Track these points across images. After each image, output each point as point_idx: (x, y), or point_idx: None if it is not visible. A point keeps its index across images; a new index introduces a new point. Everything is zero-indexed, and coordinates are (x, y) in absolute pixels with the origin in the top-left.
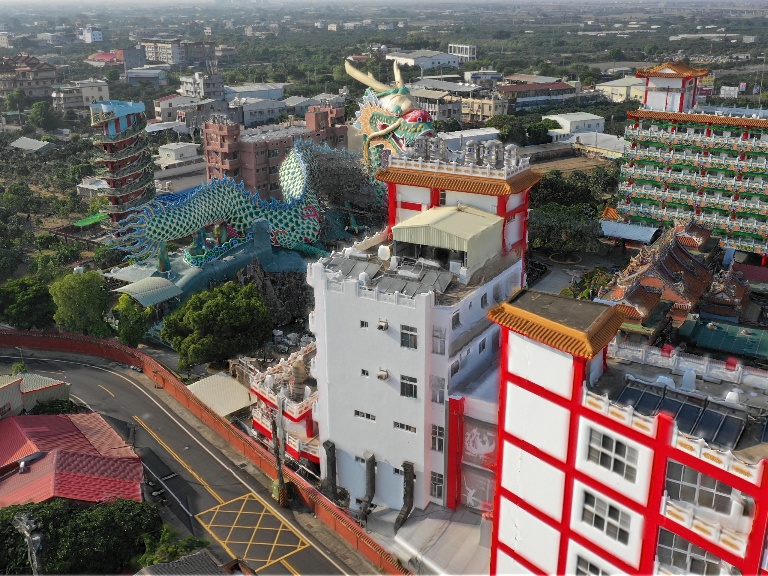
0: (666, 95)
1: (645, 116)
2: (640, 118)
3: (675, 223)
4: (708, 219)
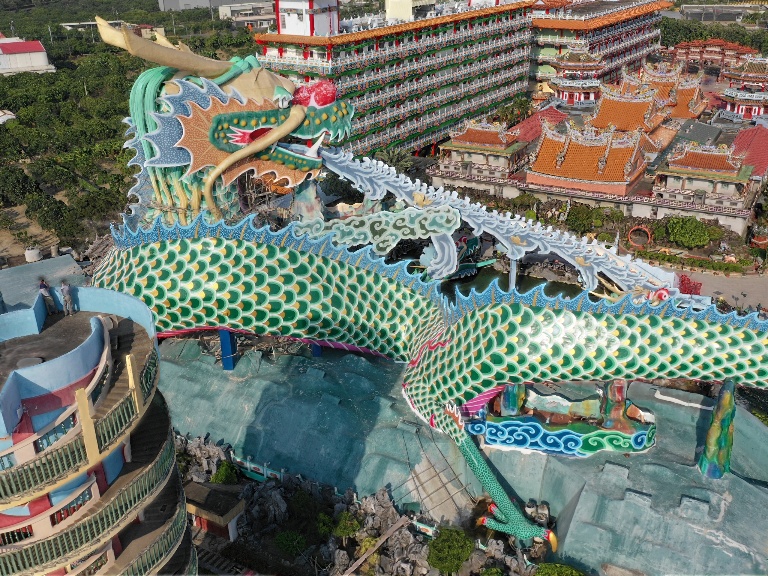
0: (329, 16)
1: (344, 42)
2: (333, 46)
3: (451, 135)
4: (392, 134)
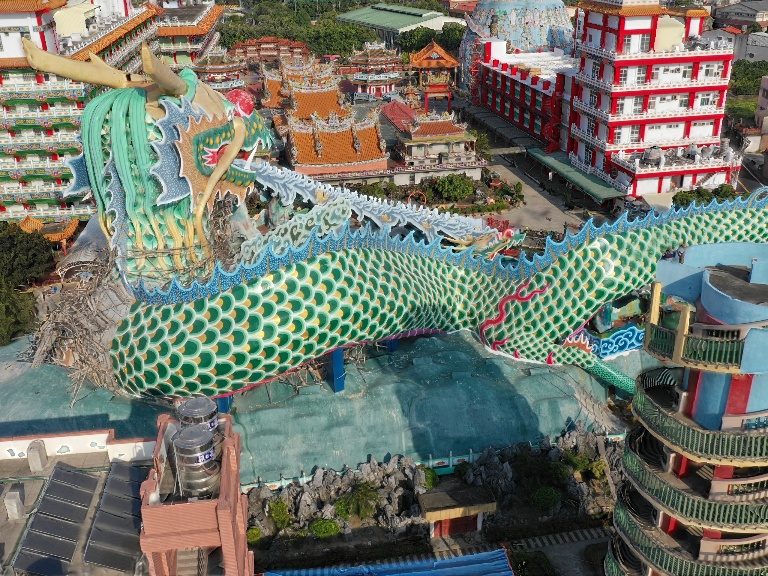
0: (53, 32)
1: None
2: None
3: None
4: None
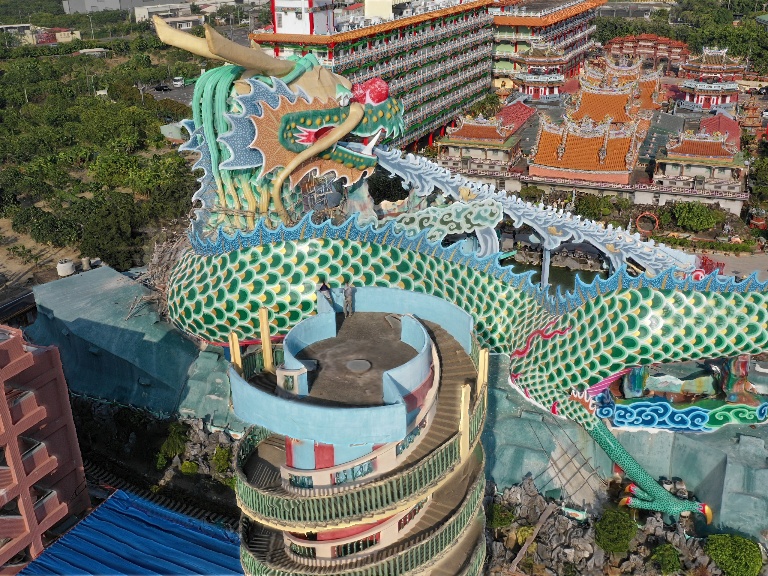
0: (326, 14)
1: (345, 40)
2: None
3: (449, 131)
4: None
